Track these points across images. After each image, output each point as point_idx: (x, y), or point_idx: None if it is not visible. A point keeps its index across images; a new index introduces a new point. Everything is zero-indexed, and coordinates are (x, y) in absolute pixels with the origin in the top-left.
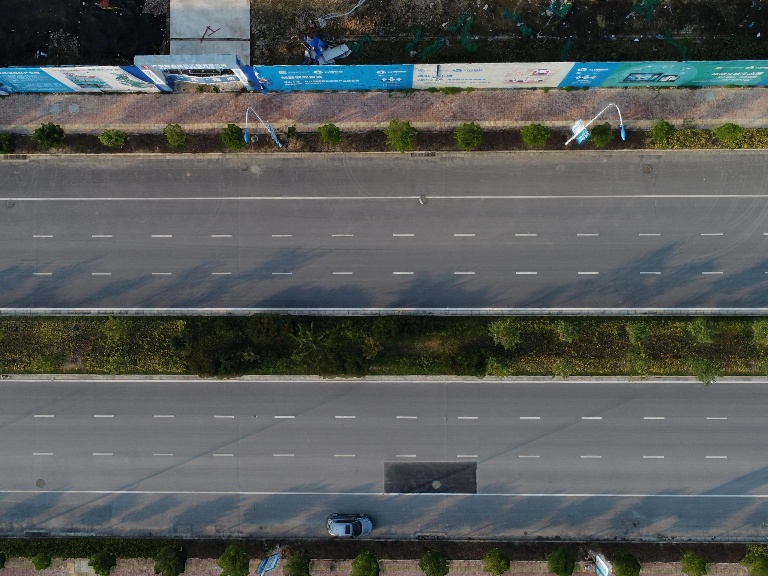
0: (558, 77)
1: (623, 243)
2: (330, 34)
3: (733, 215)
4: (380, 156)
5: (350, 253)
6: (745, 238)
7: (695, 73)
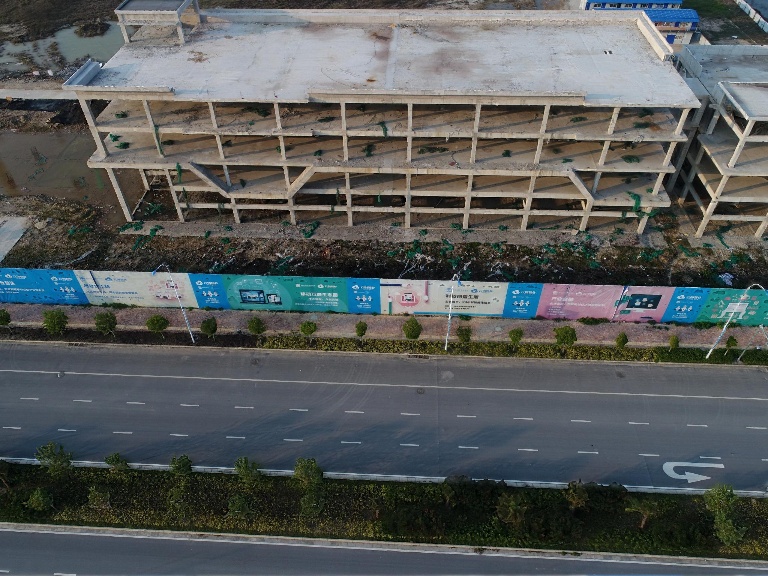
0: (190, 293)
1: (218, 413)
2: None
3: (320, 396)
4: (44, 344)
5: None
6: (328, 414)
7: (287, 292)
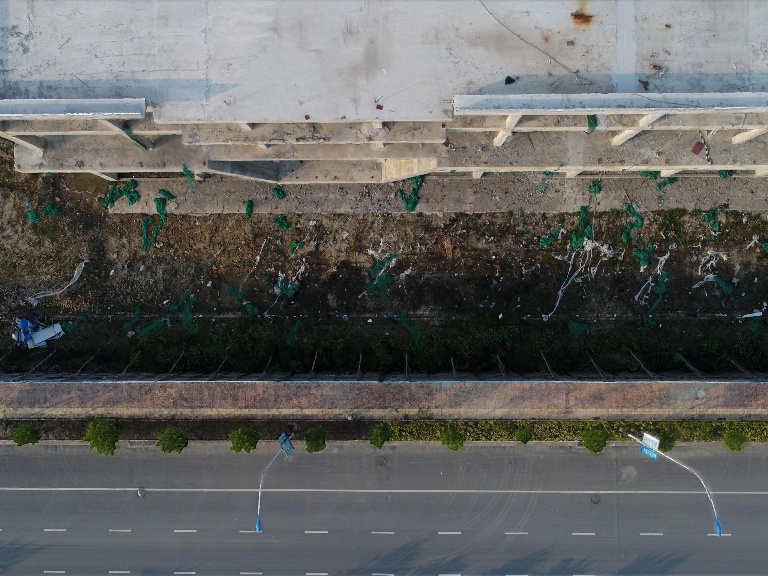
0: None
1: (354, 542)
2: (43, 313)
3: (472, 512)
4: None
5: (63, 550)
6: (485, 537)
7: None
